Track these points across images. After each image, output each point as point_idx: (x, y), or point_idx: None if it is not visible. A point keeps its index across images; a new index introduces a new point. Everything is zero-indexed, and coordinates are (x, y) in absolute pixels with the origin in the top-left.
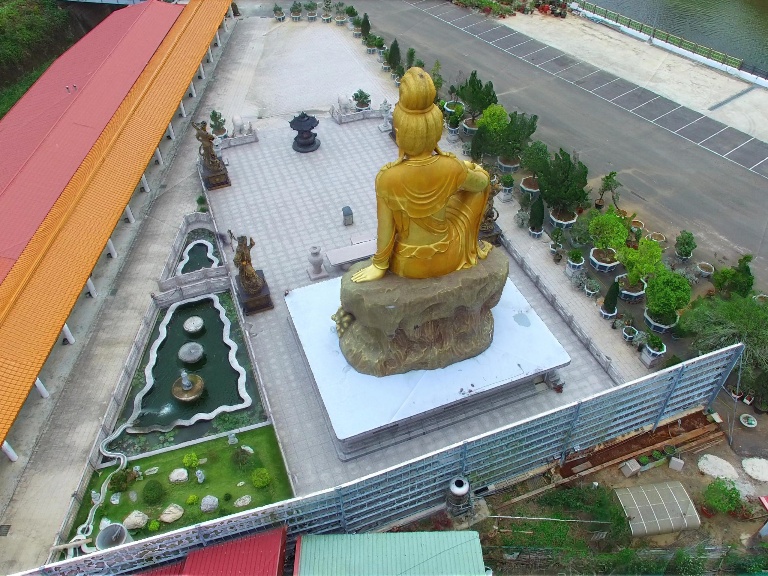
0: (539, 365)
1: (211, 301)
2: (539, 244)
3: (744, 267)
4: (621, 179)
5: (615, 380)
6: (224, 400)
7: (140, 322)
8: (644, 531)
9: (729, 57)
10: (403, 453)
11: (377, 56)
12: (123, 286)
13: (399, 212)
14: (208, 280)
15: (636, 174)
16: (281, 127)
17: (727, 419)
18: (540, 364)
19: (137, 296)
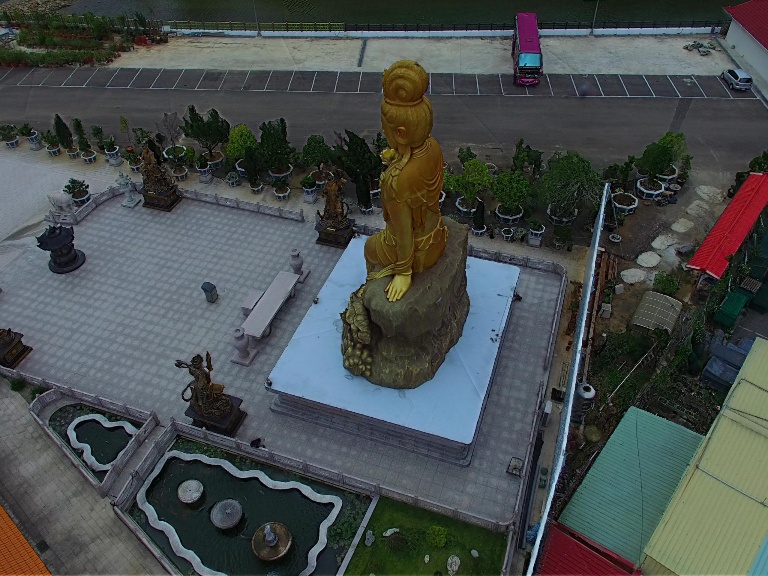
0: (509, 286)
1: (175, 460)
2: (378, 217)
3: (527, 148)
4: (368, 141)
5: (538, 267)
6: (314, 520)
7: (126, 542)
8: (670, 332)
9: (333, 24)
10: (494, 421)
11: (28, 146)
12: (45, 532)
13: (419, 207)
14: (156, 441)
15: (372, 133)
16: (7, 263)
17: (605, 246)
18: (509, 284)
19: (80, 525)
